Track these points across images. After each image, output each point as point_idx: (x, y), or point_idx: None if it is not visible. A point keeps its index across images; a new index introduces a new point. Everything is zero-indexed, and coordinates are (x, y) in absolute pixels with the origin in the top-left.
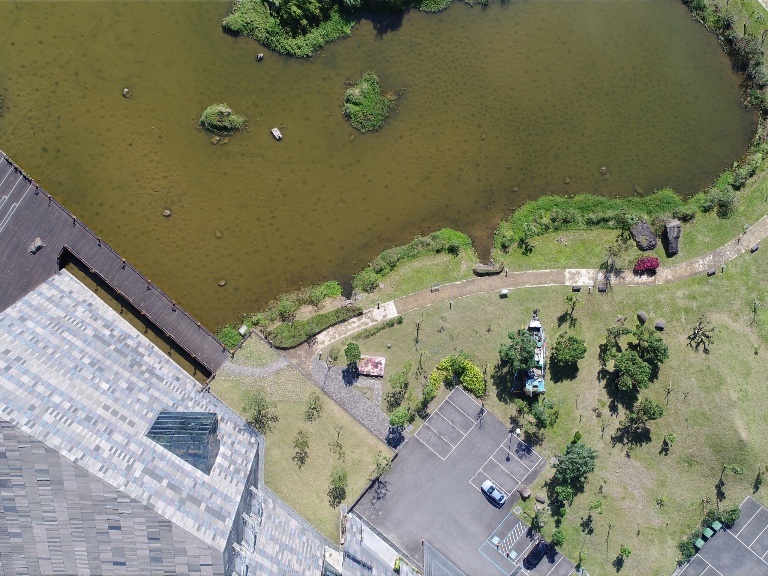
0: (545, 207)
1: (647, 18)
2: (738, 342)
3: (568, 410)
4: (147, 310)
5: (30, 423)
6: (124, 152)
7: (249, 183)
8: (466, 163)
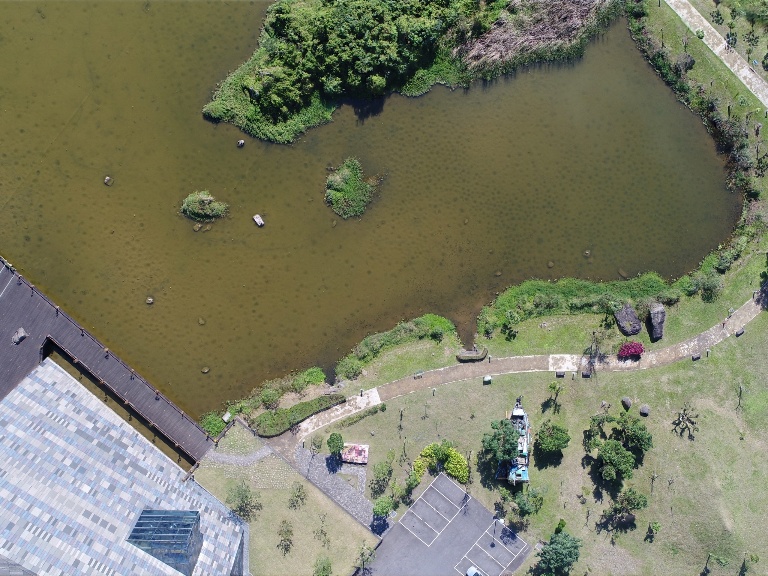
0: (528, 292)
1: (630, 100)
2: (723, 428)
3: (552, 496)
4: (131, 399)
5: (8, 544)
6: (106, 240)
7: (231, 270)
8: (449, 248)
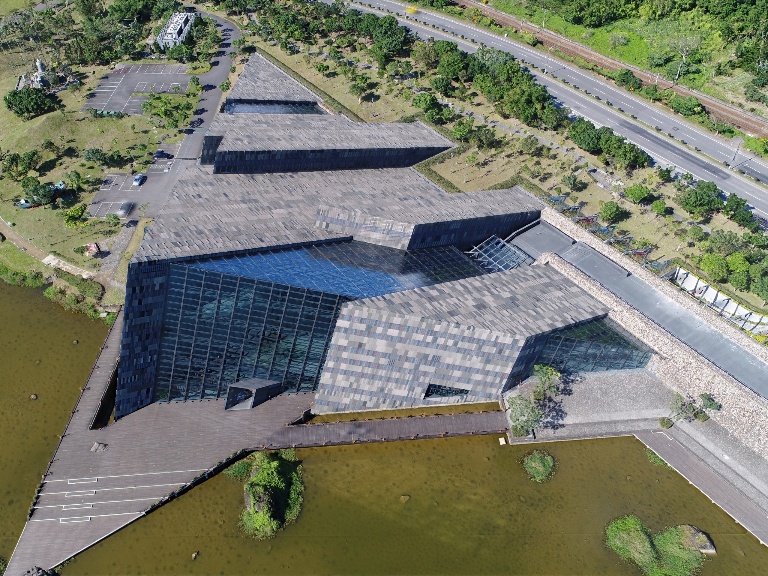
0: None
1: None
2: None
3: None
4: None
5: None
6: None
7: None
8: None
